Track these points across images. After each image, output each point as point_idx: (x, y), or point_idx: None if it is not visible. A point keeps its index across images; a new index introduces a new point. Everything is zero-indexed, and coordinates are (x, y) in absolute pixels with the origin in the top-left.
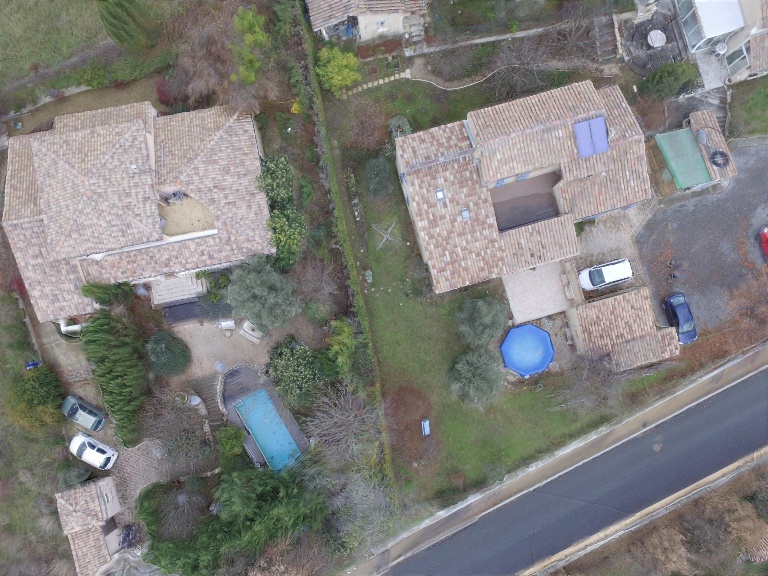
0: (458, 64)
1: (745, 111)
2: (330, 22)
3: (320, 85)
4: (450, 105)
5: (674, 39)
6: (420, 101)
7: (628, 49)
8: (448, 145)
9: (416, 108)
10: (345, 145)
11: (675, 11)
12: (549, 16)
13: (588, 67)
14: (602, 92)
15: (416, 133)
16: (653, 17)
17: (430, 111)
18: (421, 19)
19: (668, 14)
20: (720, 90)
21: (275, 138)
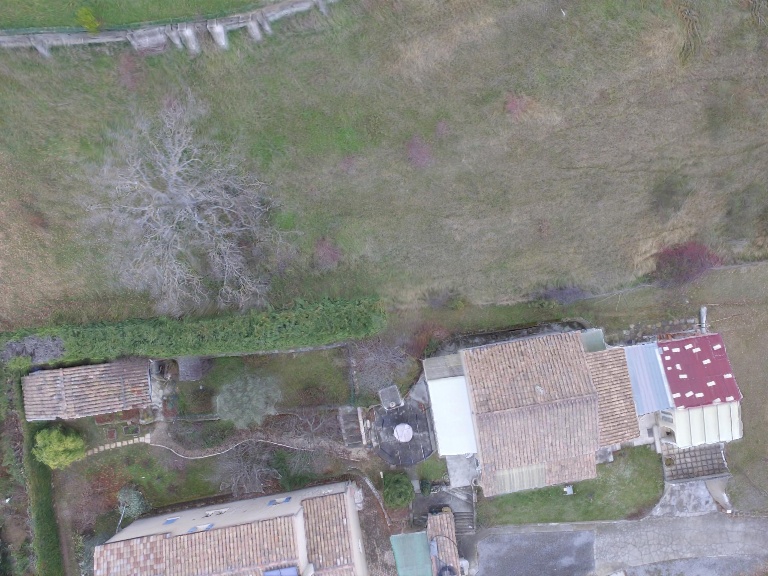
0: (200, 433)
1: (495, 507)
2: (40, 418)
3: (41, 461)
4: (189, 474)
5: (426, 429)
6: (158, 468)
7: (378, 434)
8: (144, 565)
9: (152, 475)
10: (75, 507)
11: (429, 401)
12: (293, 400)
13: (335, 448)
14: (328, 501)
15: (117, 544)
16: (406, 404)
17: (167, 479)
18: (160, 391)
19: (422, 403)
20: (467, 488)
21: (0, 498)
